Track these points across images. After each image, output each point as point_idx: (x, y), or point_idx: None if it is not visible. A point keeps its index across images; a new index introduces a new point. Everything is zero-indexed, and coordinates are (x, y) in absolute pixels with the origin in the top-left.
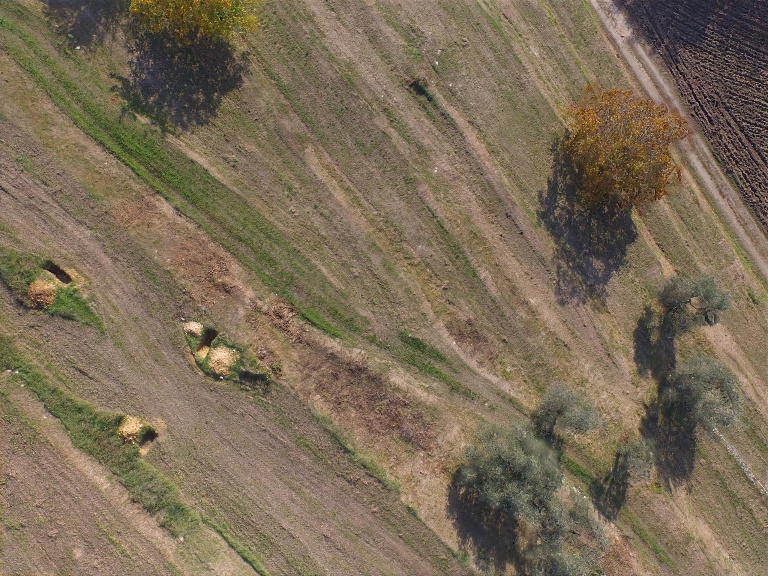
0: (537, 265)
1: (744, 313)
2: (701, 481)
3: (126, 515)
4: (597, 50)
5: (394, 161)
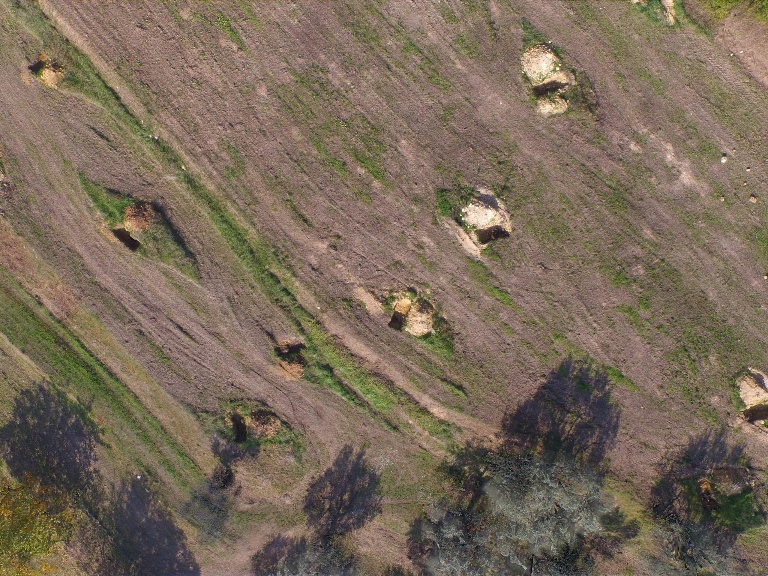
0: None
1: None
2: None
3: None
4: None
5: None
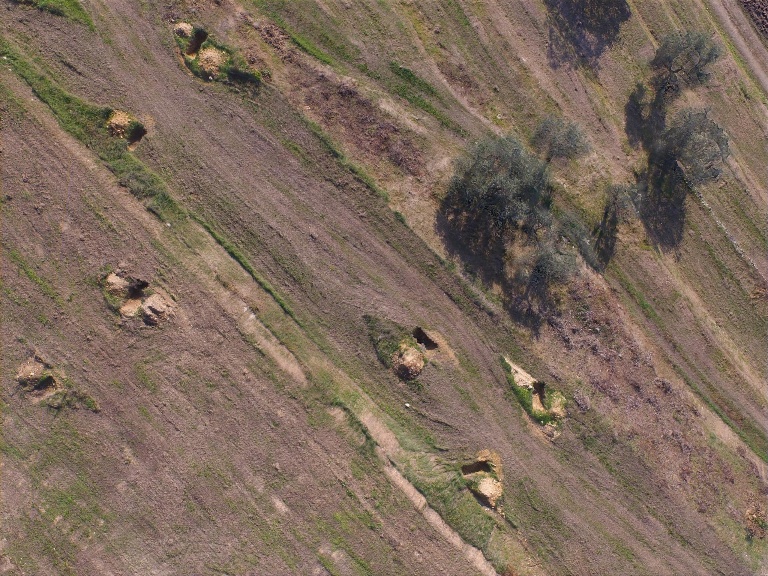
0: (530, 27)
1: (736, 106)
2: (689, 251)
3: (113, 193)
4: None
5: None
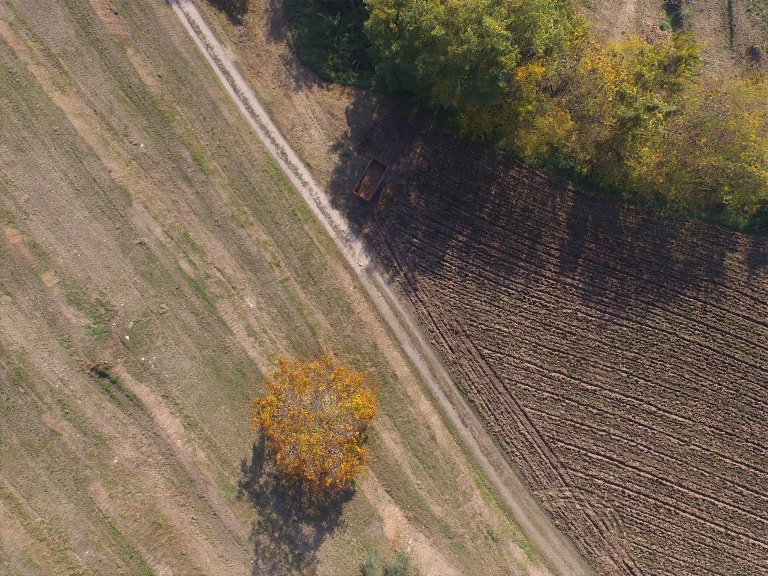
0: (233, 545)
1: (481, 553)
2: None
3: None
4: (326, 288)
5: (63, 460)
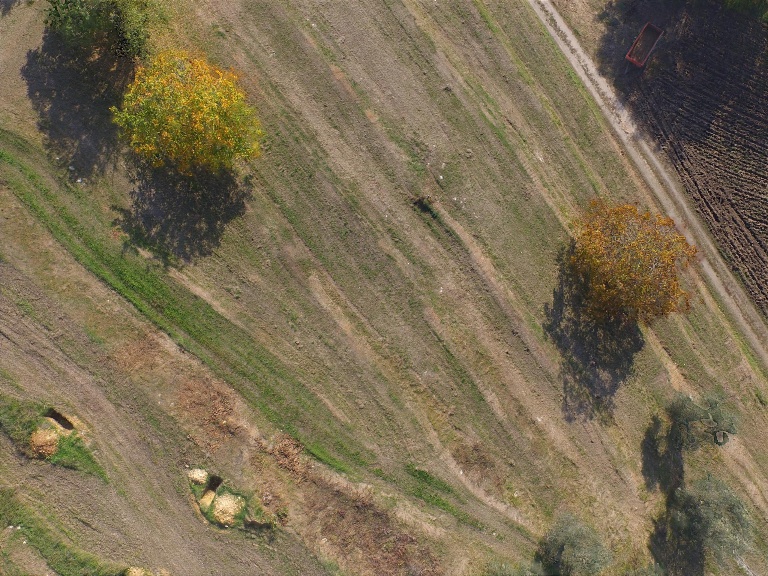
0: (544, 381)
1: (752, 415)
2: None
3: None
4: (602, 150)
5: (399, 284)
